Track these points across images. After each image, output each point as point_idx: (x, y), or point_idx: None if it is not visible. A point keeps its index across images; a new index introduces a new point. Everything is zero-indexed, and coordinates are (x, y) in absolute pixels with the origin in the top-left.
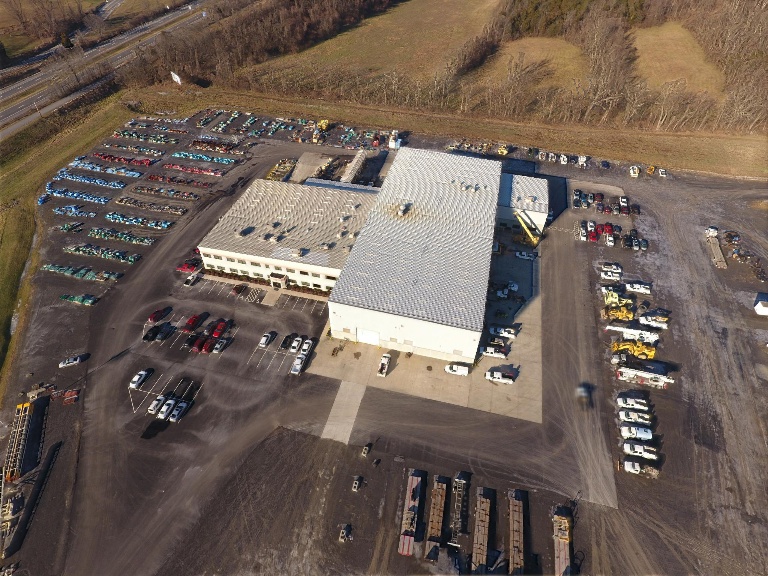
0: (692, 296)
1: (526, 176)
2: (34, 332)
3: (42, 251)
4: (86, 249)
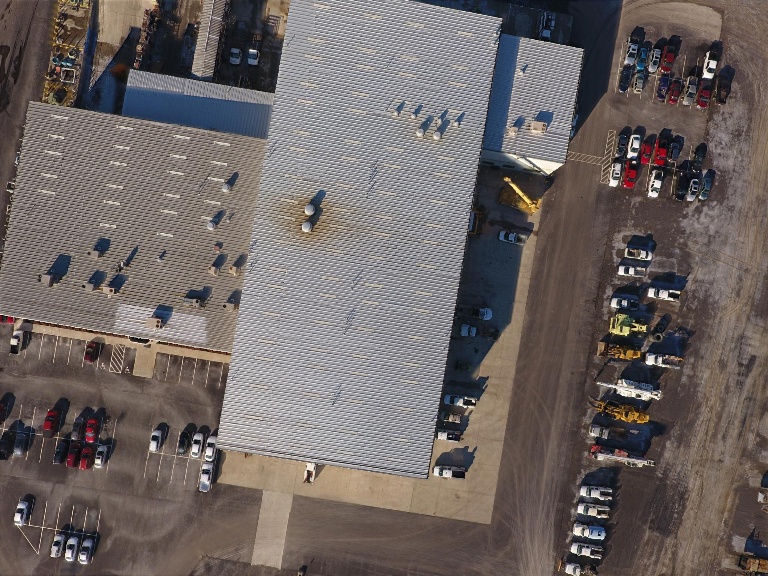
0: (735, 298)
1: (545, 41)
2: None
3: None
4: None
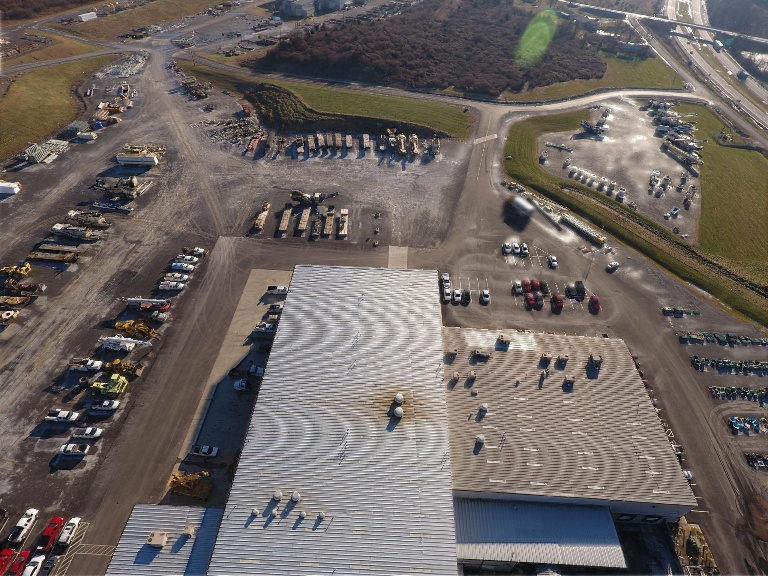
0: None
1: None
2: (672, 283)
3: None
4: (763, 365)
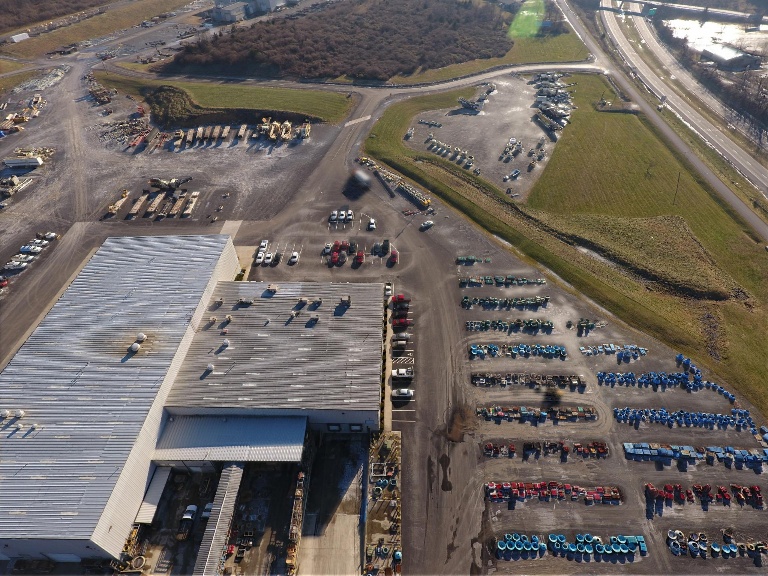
0: None
1: None
2: (478, 237)
3: (572, 296)
4: None
